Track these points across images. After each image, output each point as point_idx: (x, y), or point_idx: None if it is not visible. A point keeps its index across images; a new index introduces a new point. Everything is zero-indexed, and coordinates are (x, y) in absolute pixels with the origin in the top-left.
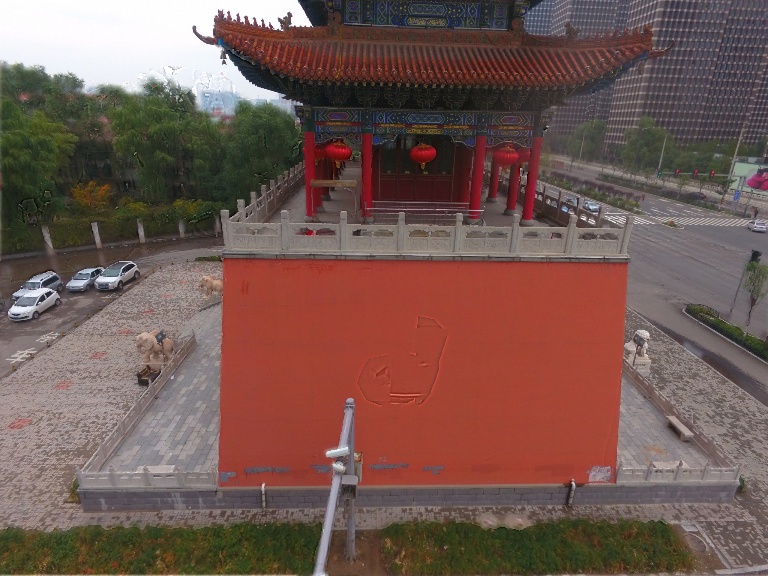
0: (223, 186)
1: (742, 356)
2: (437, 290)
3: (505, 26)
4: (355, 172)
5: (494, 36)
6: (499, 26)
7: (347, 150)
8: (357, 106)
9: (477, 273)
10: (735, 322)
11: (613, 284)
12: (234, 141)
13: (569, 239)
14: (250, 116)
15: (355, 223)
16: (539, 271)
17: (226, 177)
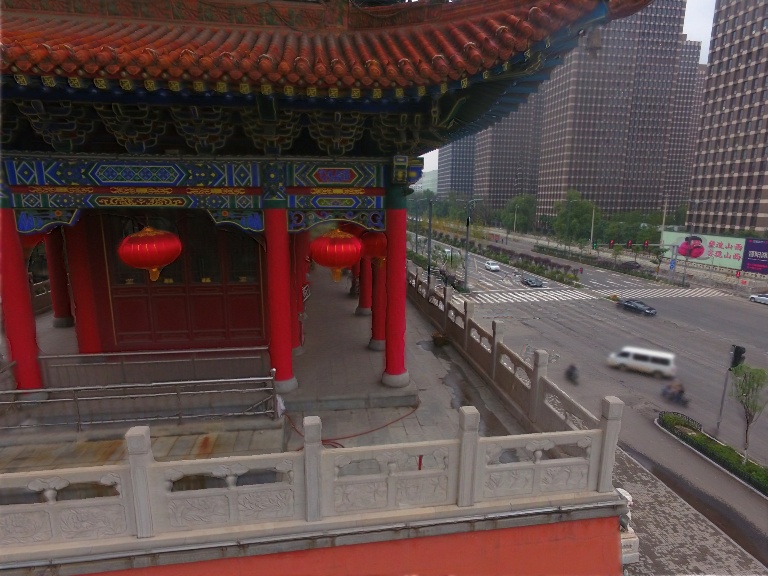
0: None
1: (752, 501)
2: None
3: None
4: None
5: (289, 11)
6: None
7: None
8: None
9: None
10: (722, 436)
11: (589, 571)
12: None
13: (464, 470)
14: None
15: None
16: (392, 563)
17: None
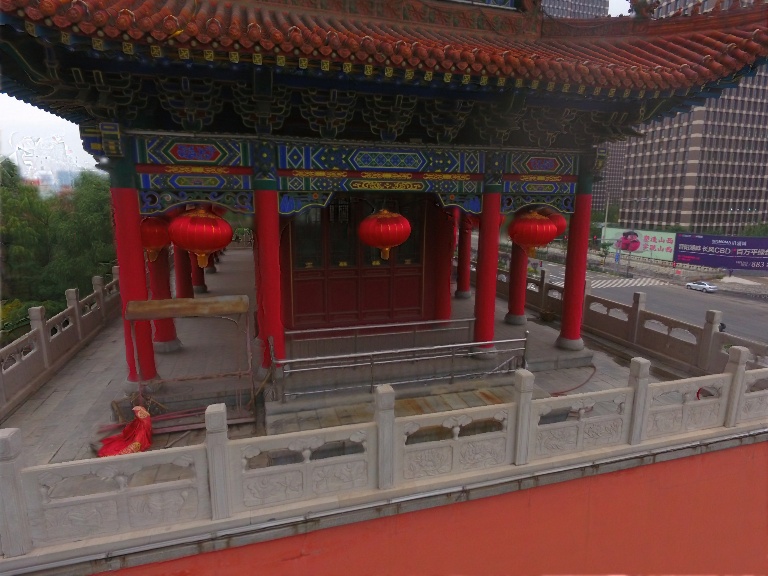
0: (52, 280)
1: None
2: (482, 569)
3: (510, 5)
4: (240, 257)
5: (496, 18)
6: (500, 4)
7: (221, 227)
8: (240, 131)
9: (570, 507)
10: None
11: None
12: (67, 221)
13: (734, 397)
14: (91, 189)
15: (249, 382)
16: (687, 475)
17: (56, 268)
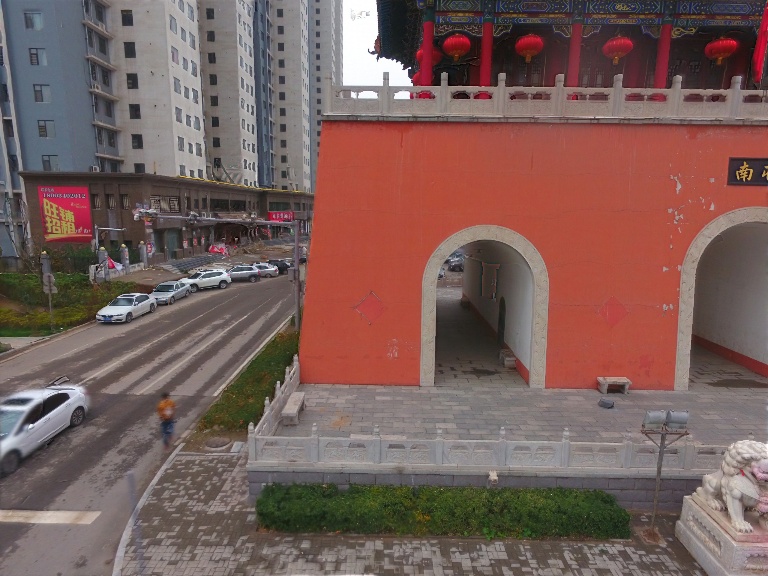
0: None
1: None
2: None
3: None
4: None
5: None
6: None
7: None
8: None
9: None
10: None
11: None
12: None
13: None
14: None
15: None
16: None
17: None
